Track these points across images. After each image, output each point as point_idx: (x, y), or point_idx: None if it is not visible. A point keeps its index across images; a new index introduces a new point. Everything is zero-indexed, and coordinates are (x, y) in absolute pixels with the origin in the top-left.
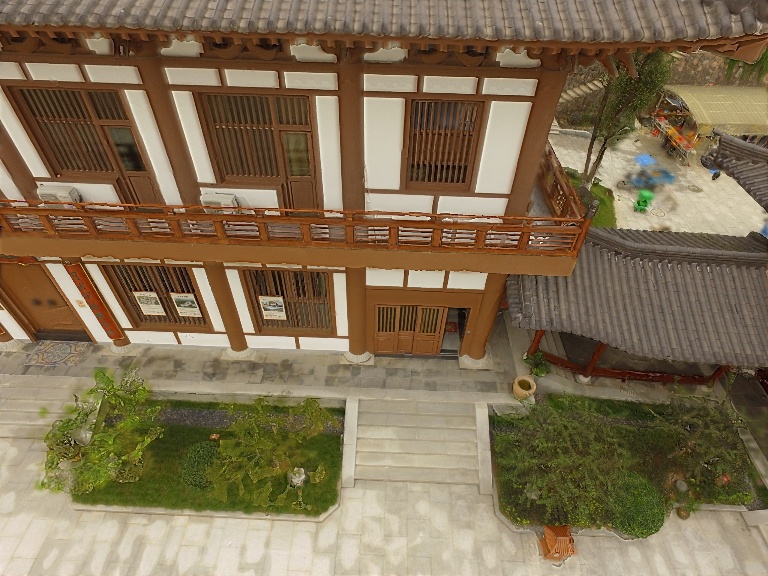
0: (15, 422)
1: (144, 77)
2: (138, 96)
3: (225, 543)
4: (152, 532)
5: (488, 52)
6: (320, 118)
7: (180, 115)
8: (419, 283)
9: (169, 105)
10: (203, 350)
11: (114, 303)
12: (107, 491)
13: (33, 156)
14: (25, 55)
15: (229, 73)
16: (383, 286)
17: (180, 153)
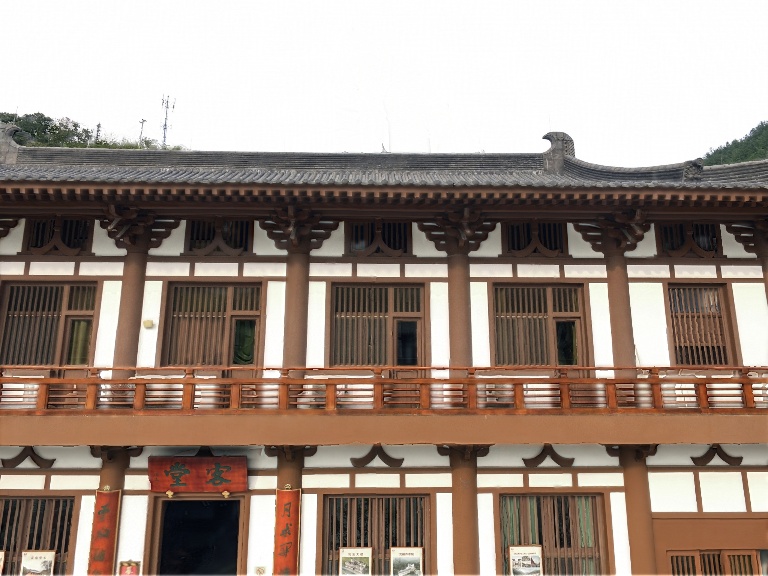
0: None
1: (453, 269)
2: (440, 287)
3: None
4: None
5: (715, 250)
6: (592, 302)
7: (471, 302)
8: (715, 505)
9: (466, 293)
10: None
11: (309, 571)
12: None
13: (318, 347)
14: (360, 258)
15: (520, 267)
16: (673, 512)
17: (465, 336)
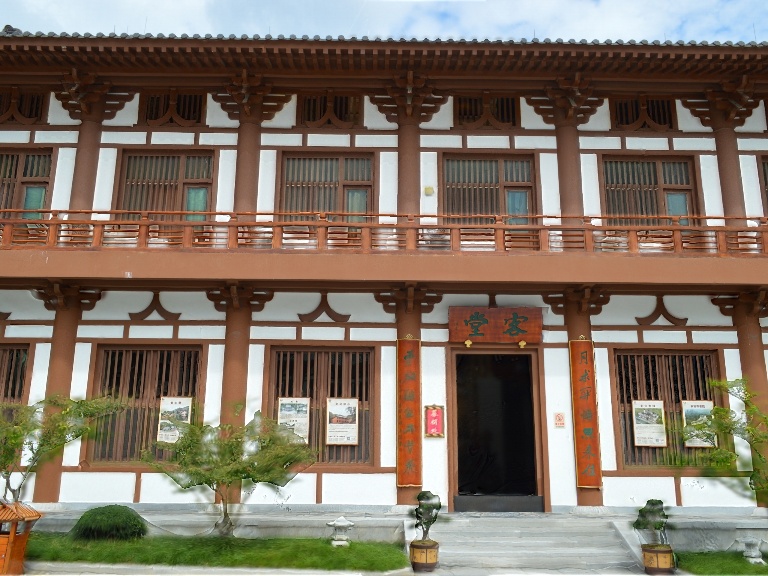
0: (511, 551)
1: (723, 142)
2: (709, 160)
3: None
4: None
5: None
6: None
7: (742, 174)
8: None
9: (736, 165)
10: (717, 514)
11: (606, 418)
12: None
13: (594, 214)
14: (628, 132)
15: None
16: None
17: (739, 204)
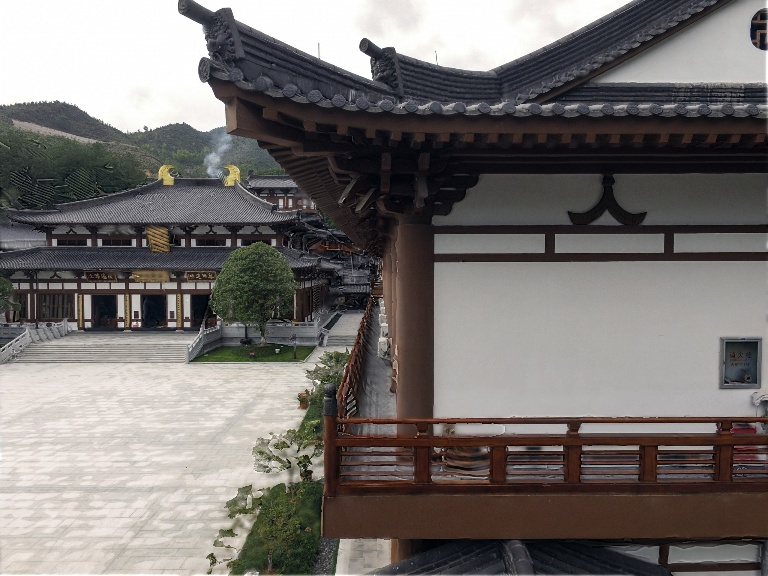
0: None
1: None
2: None
3: (217, 559)
4: (242, 523)
5: None
6: None
7: None
8: None
9: None
10: None
11: None
12: (274, 493)
13: None
14: None
15: None
16: None
17: None
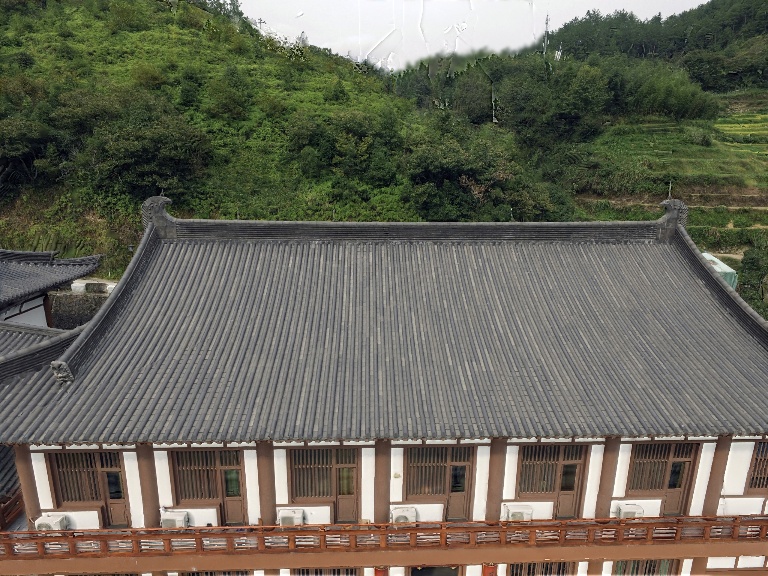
0: None
1: None
2: (599, 448)
3: None
4: None
5: None
6: (702, 454)
7: (619, 457)
8: (746, 564)
9: None
10: None
11: None
12: None
13: (511, 486)
14: None
15: None
16: (719, 568)
17: (612, 480)
